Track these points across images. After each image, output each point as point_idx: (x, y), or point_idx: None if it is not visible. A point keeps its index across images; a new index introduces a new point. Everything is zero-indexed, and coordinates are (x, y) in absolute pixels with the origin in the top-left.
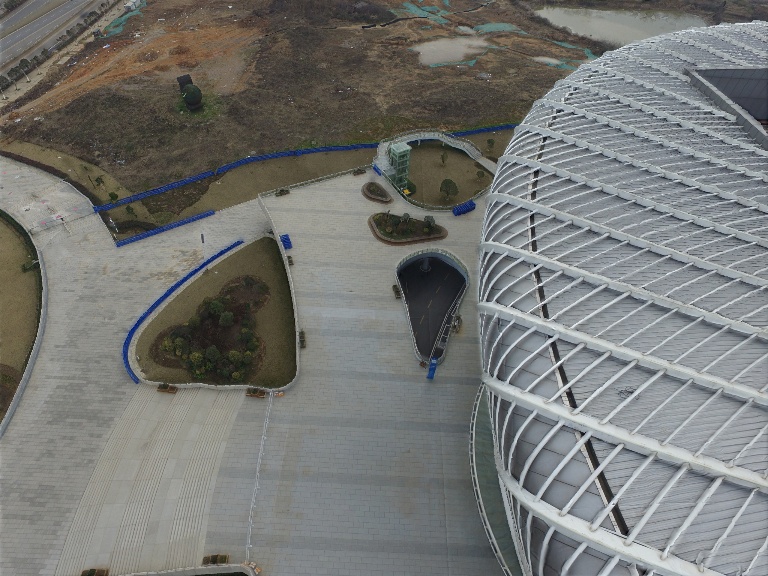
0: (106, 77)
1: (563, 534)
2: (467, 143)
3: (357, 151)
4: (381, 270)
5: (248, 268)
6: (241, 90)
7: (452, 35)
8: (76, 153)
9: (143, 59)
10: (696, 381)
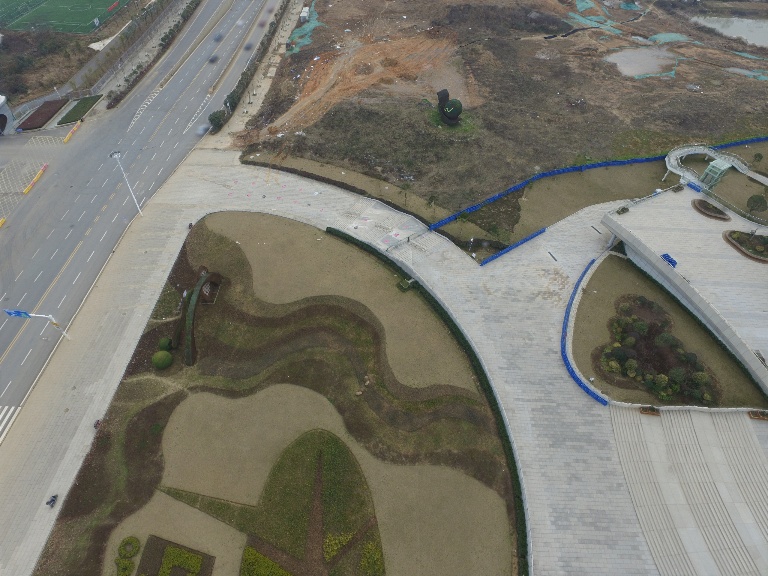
0: (339, 90)
1: None
2: (733, 157)
3: (632, 166)
4: None
5: (624, 287)
6: (480, 103)
7: (633, 46)
8: (358, 169)
9: (361, 71)
10: None
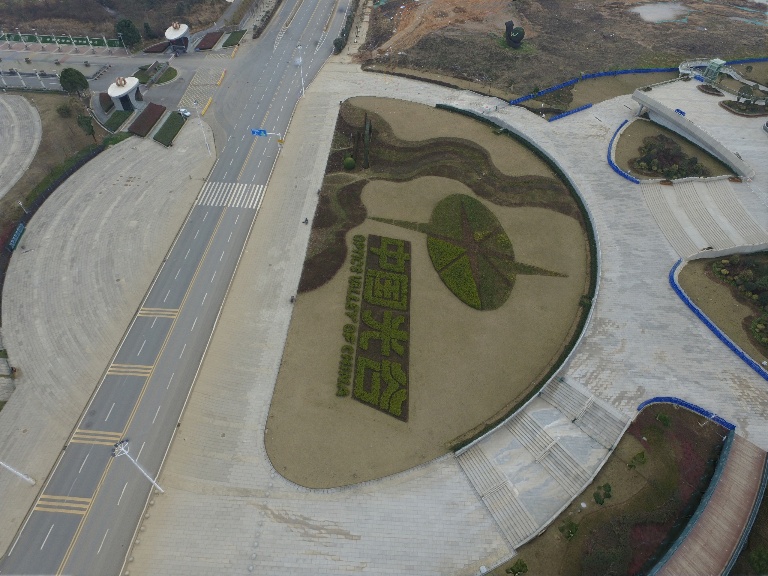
0: (425, 27)
1: None
2: None
3: (653, 74)
4: (752, 129)
5: (649, 133)
6: (535, 35)
7: (653, 2)
8: (450, 74)
9: (439, 15)
10: None
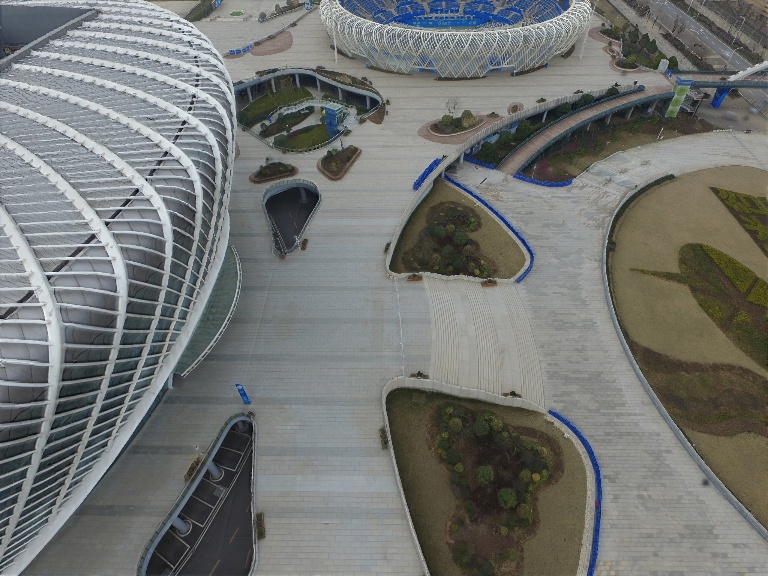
0: None
1: None
2: None
3: None
4: None
5: None
6: None
7: None
8: None
9: None
10: None
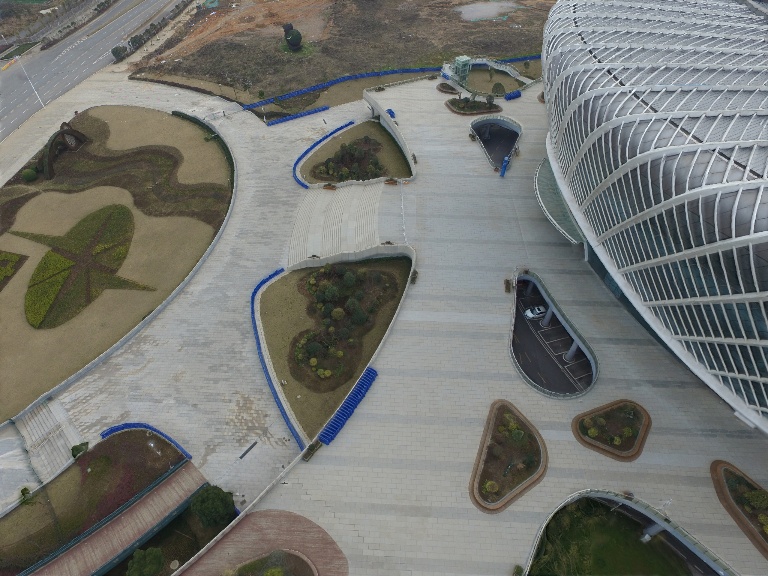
0: (220, 33)
1: (598, 96)
2: (508, 66)
3: (424, 73)
4: (459, 128)
5: (363, 135)
6: (327, 38)
7: None
8: (214, 80)
9: (244, 21)
10: (657, 47)
